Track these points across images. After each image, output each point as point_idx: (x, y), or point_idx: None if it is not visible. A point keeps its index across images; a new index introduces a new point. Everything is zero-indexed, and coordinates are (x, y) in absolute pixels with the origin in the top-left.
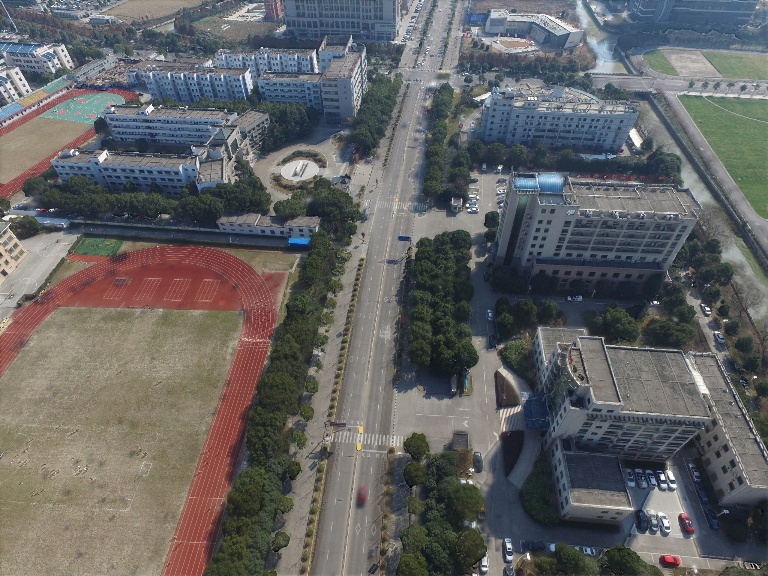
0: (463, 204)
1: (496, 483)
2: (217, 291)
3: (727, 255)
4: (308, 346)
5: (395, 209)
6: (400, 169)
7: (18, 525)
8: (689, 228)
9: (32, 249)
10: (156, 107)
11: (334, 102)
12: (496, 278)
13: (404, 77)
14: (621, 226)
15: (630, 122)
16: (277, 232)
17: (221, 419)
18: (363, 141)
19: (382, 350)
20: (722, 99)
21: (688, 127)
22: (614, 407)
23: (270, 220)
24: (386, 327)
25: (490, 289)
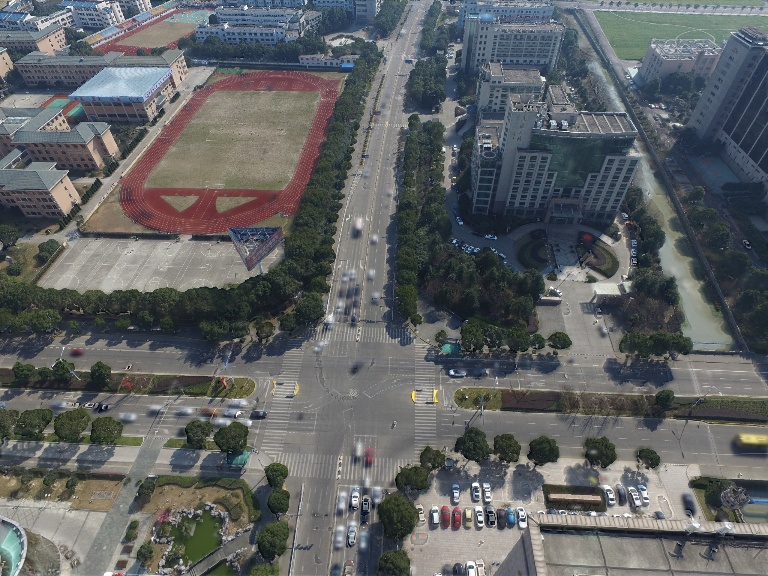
0: (444, 55)
1: (452, 134)
2: (304, 85)
3: (591, 70)
4: (358, 100)
5: (403, 57)
6: (406, 42)
7: (230, 146)
8: (559, 38)
9: (191, 72)
10: (249, 7)
11: (363, 7)
12: (459, 74)
13: (409, 2)
14: (524, 39)
15: (549, 13)
16: (334, 64)
17: (317, 121)
18: (383, 26)
19: (397, 102)
20: (622, 12)
21: (593, 24)
22: (500, 78)
23: (330, 57)
24: (399, 96)
25: (456, 83)
